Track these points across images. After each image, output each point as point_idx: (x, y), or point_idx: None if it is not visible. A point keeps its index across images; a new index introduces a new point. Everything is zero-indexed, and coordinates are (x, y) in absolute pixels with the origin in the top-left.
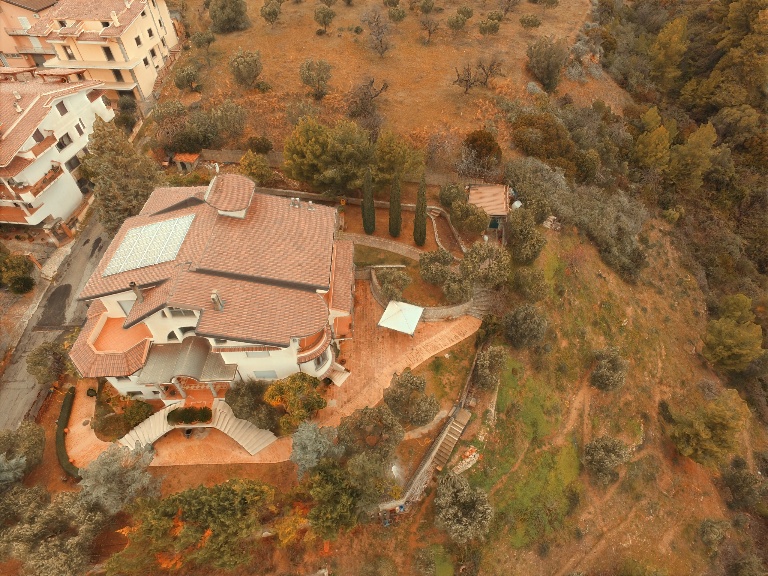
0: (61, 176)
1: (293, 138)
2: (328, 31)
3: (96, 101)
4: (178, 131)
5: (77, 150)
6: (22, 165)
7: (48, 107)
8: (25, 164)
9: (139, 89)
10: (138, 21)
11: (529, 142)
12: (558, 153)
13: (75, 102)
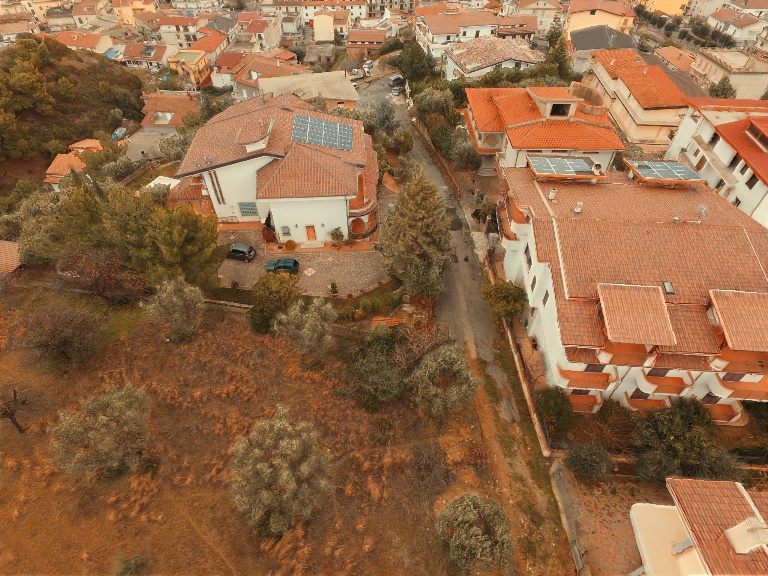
0: None
1: (195, 215)
2: None
3: None
4: (402, 329)
5: None
6: (506, 190)
7: (522, 205)
8: (505, 191)
9: (639, 572)
10: None
11: None
12: None
13: None
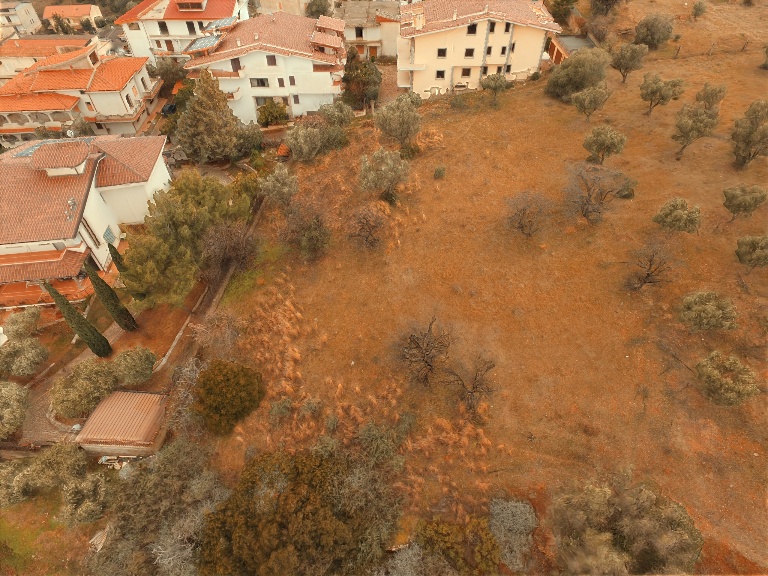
0: (231, 100)
1: None
2: (603, 166)
3: (321, 73)
4: None
5: (271, 94)
6: None
7: (244, 52)
8: None
9: None
10: (457, 35)
11: (247, 482)
12: (256, 567)
13: (295, 63)
